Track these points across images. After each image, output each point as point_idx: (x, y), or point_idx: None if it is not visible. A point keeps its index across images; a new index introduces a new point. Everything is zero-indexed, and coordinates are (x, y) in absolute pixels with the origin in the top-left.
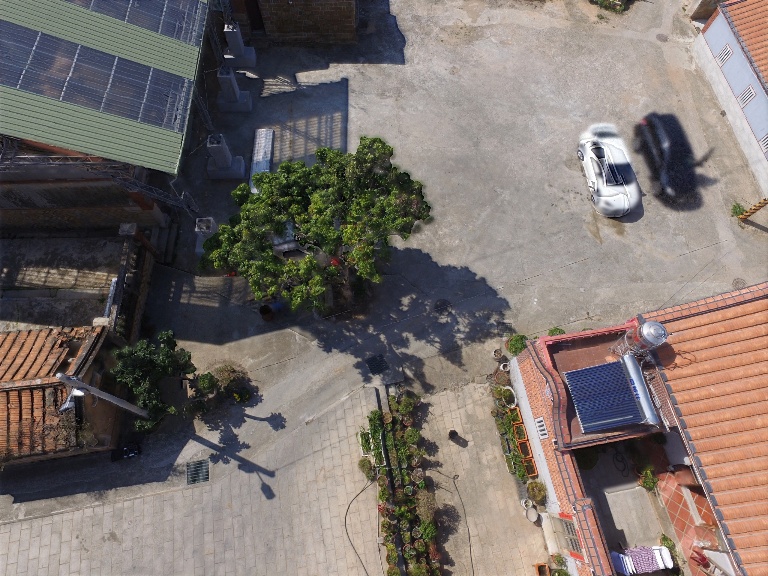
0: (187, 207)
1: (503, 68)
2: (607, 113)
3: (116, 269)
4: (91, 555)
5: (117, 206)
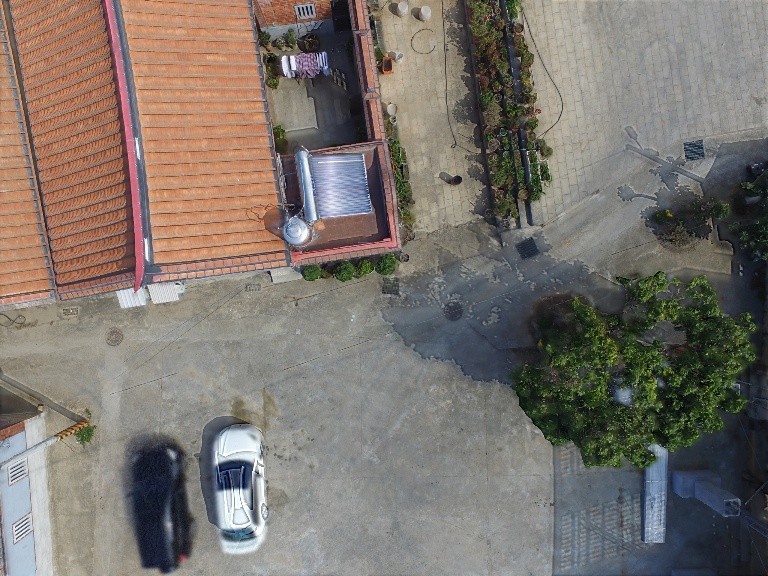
0: None
1: None
2: None
3: None
4: None
5: None
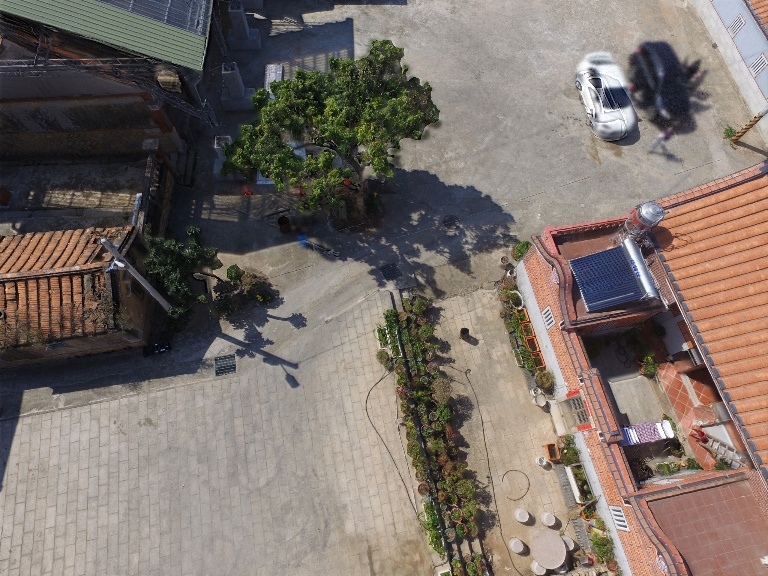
0: (208, 119)
1: (502, 7)
2: (603, 47)
3: (138, 191)
4: (129, 438)
5: (138, 128)
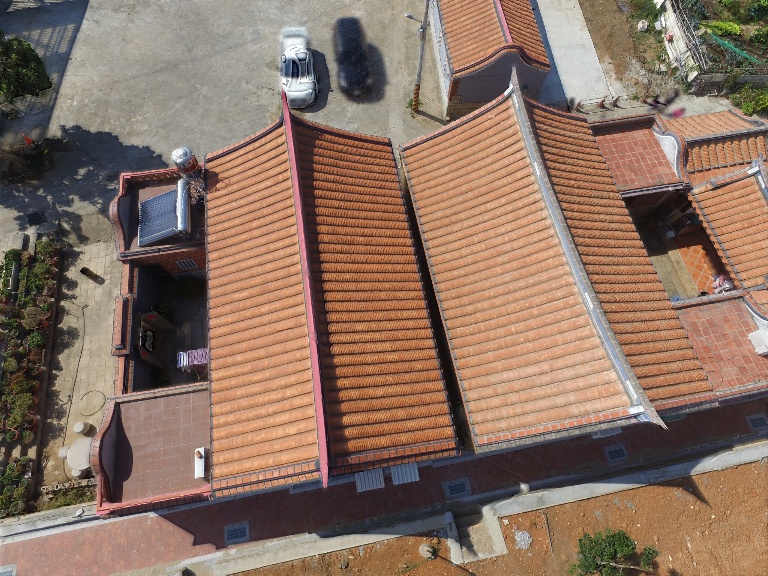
0: None
1: None
2: (321, 25)
3: None
4: None
5: None
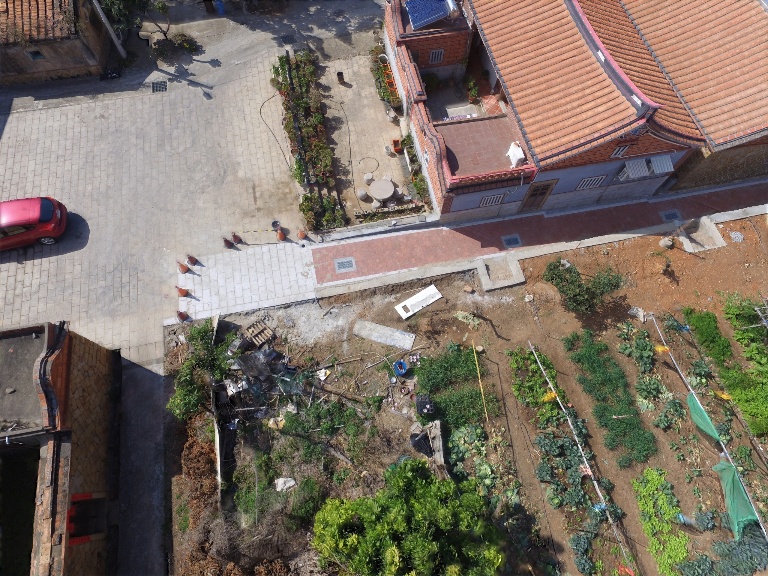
0: None
1: None
2: None
3: None
4: (88, 125)
5: None
